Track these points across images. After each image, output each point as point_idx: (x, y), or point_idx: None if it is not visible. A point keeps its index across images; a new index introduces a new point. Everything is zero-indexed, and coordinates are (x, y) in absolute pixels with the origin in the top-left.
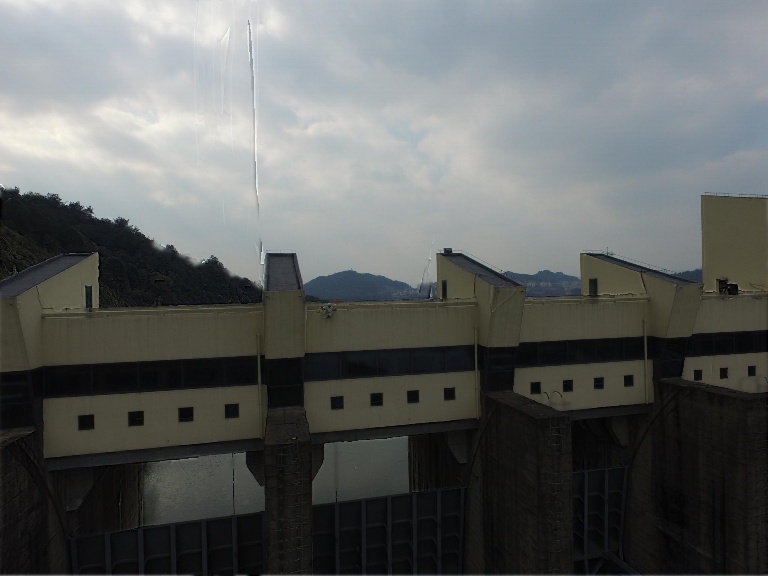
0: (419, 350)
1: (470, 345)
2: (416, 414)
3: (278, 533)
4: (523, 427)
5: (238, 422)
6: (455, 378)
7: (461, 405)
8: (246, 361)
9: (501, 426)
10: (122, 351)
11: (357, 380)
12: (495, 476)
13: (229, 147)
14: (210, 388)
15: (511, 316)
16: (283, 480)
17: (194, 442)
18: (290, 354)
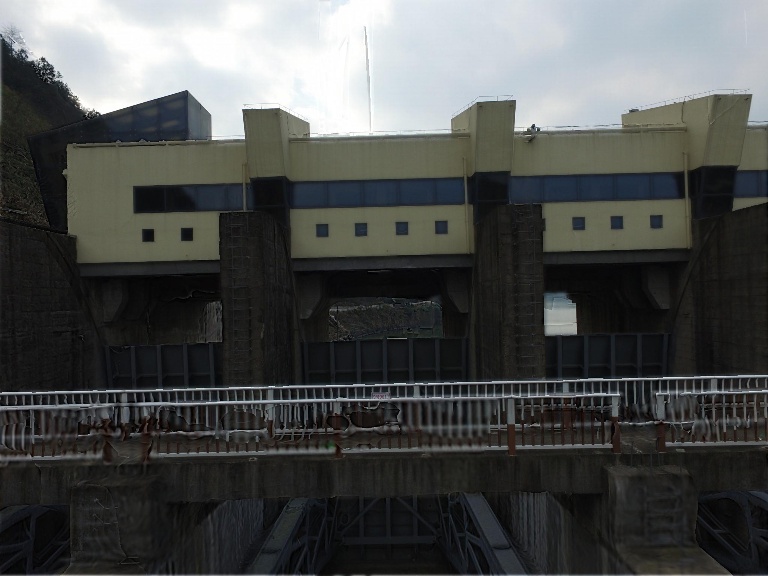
0: (622, 176)
1: (679, 172)
2: (620, 240)
3: (513, 287)
4: (762, 219)
5: (447, 238)
6: (662, 206)
7: (669, 234)
8: (453, 183)
9: (725, 238)
10: (349, 171)
11: (558, 204)
12: (716, 297)
13: None
14: (422, 206)
15: (732, 129)
16: (517, 237)
17: (409, 253)
18: (498, 167)
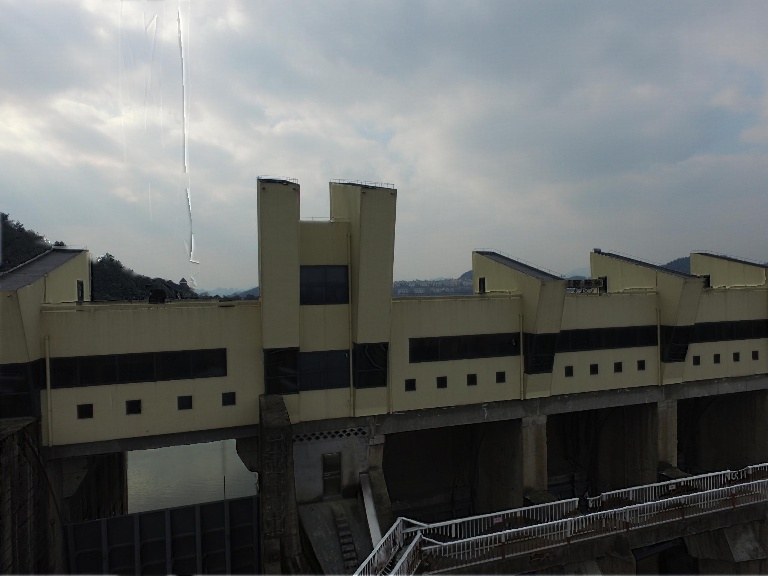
0: None
1: None
2: None
3: None
4: None
5: None
6: None
7: None
8: None
9: None
10: None
11: None
12: None
13: (159, 140)
14: None
15: None
16: None
17: None
18: None
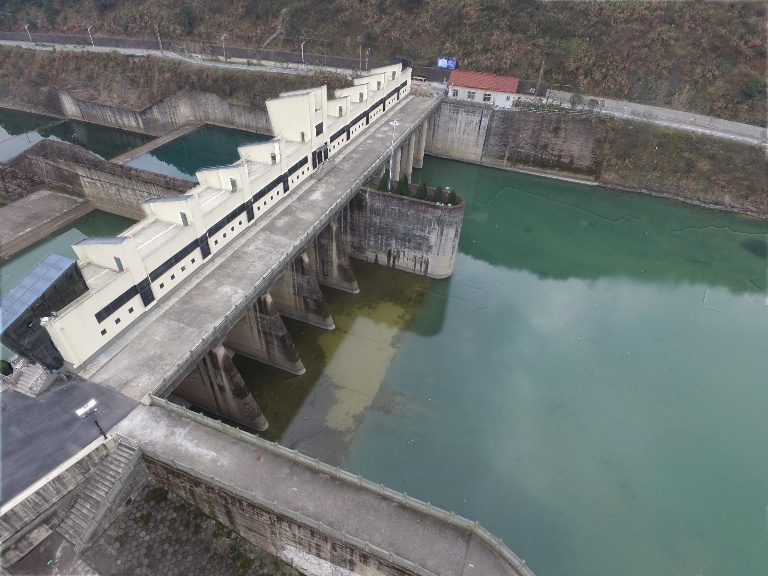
0: None
1: None
2: None
3: None
4: None
5: None
6: None
7: None
8: None
9: None
10: None
11: None
12: None
13: None
14: None
15: None
16: None
17: None
18: None
